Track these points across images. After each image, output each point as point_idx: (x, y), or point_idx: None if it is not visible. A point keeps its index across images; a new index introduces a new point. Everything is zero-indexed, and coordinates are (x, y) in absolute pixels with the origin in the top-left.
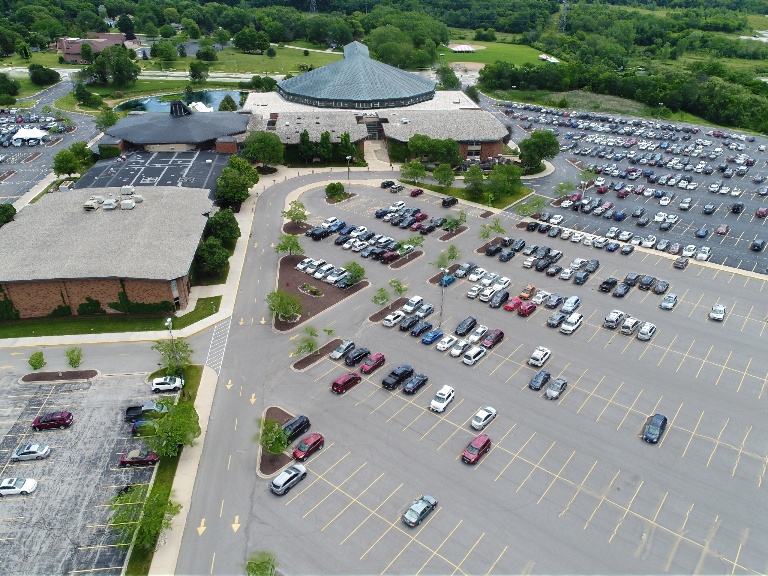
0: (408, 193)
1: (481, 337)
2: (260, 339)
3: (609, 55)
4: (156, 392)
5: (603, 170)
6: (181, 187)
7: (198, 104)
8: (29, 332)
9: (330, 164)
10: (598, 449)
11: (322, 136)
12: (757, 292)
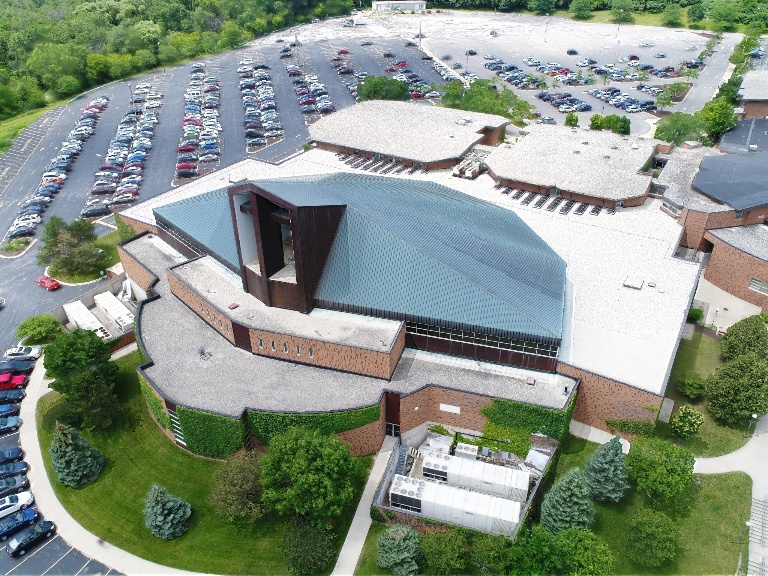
0: None
1: None
2: None
3: None
4: None
5: None
6: None
7: None
8: None
9: None
10: (595, 55)
11: None
12: (455, 58)
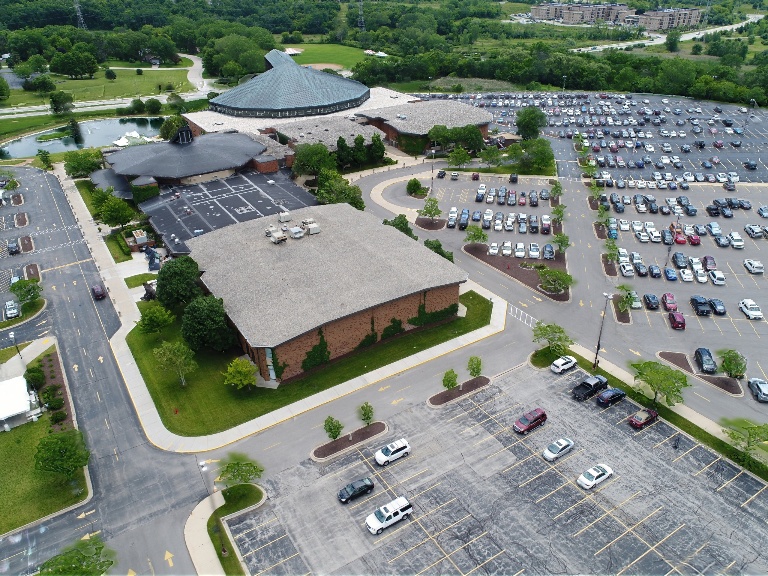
0: (467, 178)
1: (702, 264)
2: (561, 312)
3: (434, 45)
4: (561, 373)
5: (574, 134)
6: (321, 205)
7: (132, 134)
8: (362, 368)
9: (364, 167)
10: None
11: (357, 140)
12: None
